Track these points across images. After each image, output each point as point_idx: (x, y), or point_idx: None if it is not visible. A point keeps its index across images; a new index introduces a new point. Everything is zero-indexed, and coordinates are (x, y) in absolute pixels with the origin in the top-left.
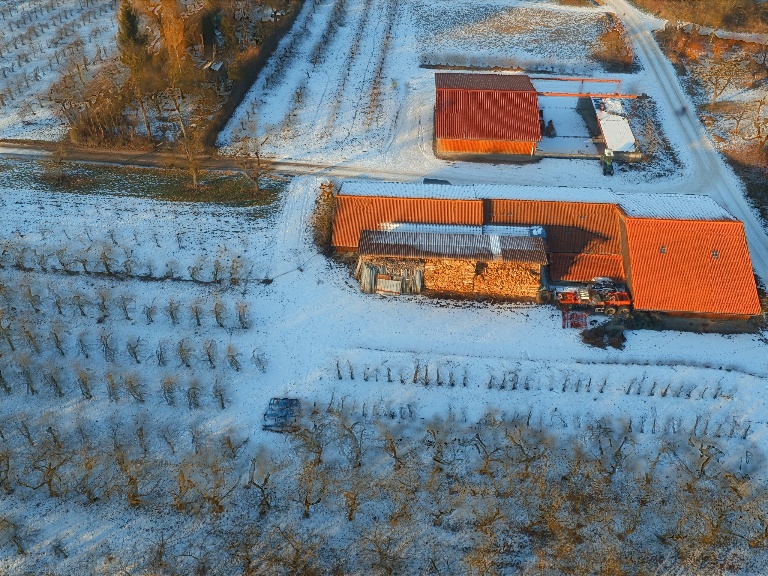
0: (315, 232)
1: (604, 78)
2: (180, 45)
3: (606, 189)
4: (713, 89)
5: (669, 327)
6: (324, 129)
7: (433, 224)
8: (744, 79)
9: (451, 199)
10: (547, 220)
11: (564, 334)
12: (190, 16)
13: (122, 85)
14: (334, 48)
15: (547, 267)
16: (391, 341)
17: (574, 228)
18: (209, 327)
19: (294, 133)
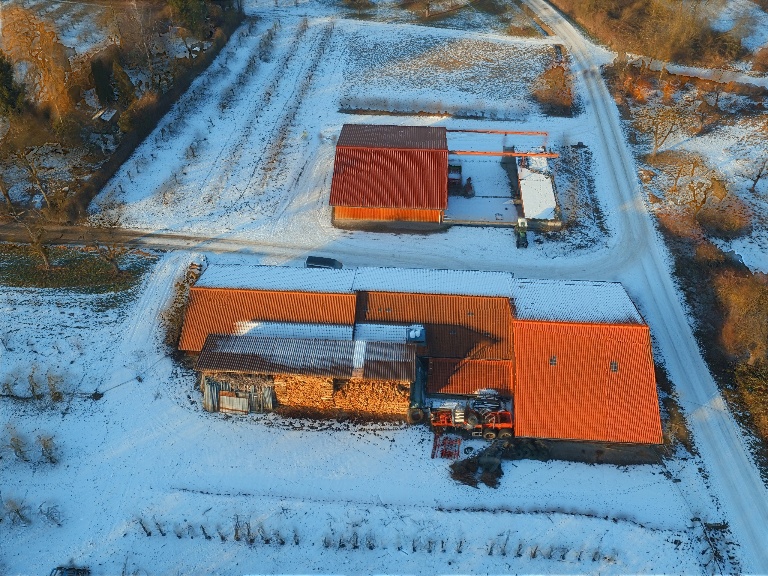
0: (169, 327)
1: (539, 124)
2: (78, 88)
3: (507, 274)
4: (657, 136)
5: (557, 456)
6: (214, 191)
7: (297, 323)
8: (693, 123)
9: (321, 292)
10: (429, 317)
11: (431, 466)
12: (94, 55)
13: (2, 137)
14: (251, 89)
15: (426, 374)
16: (224, 478)
17: (460, 327)
18: (11, 461)
19: (179, 196)
